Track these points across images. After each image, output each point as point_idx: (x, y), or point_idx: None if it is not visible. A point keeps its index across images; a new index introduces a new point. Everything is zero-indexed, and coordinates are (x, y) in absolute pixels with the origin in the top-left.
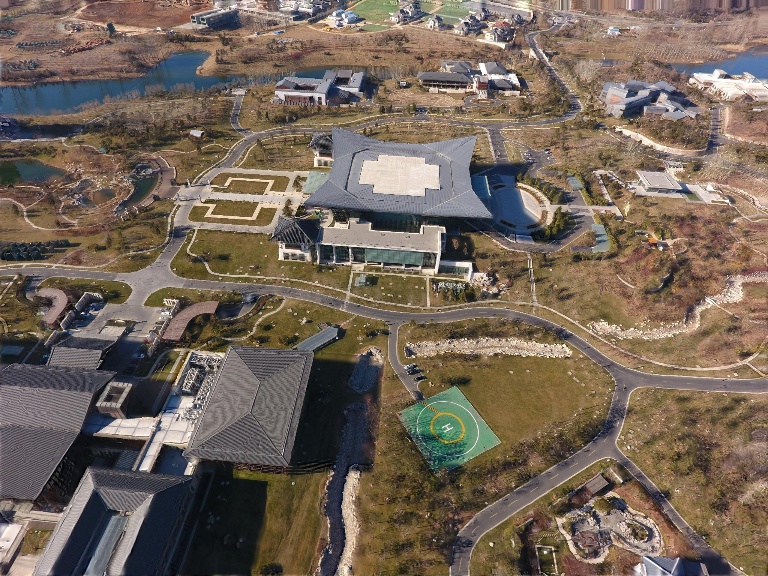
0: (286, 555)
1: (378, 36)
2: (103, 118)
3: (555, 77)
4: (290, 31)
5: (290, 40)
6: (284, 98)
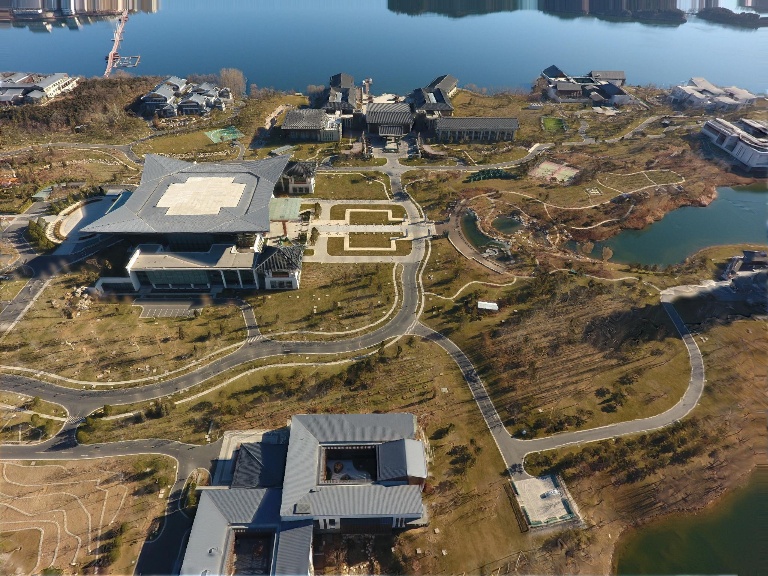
0: None
1: None
2: None
3: None
4: None
5: None
6: None
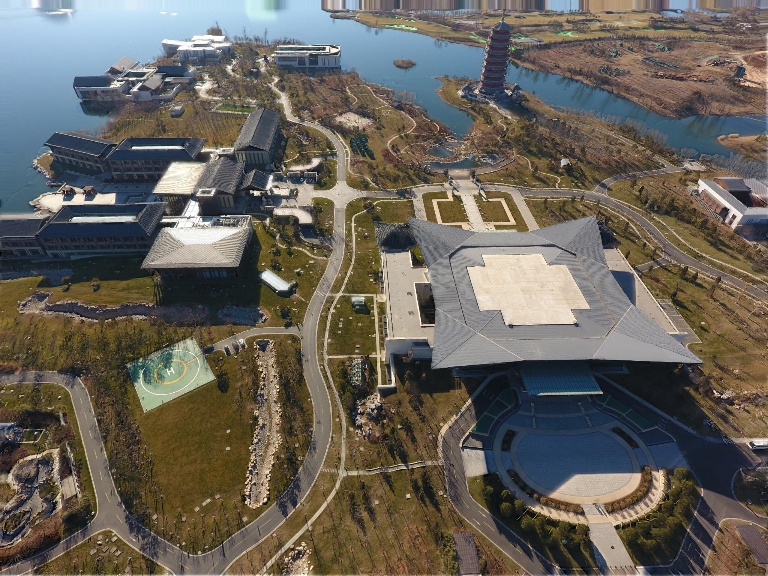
0: (102, 291)
1: None
2: (553, 120)
3: None
4: None
5: None
6: (702, 192)
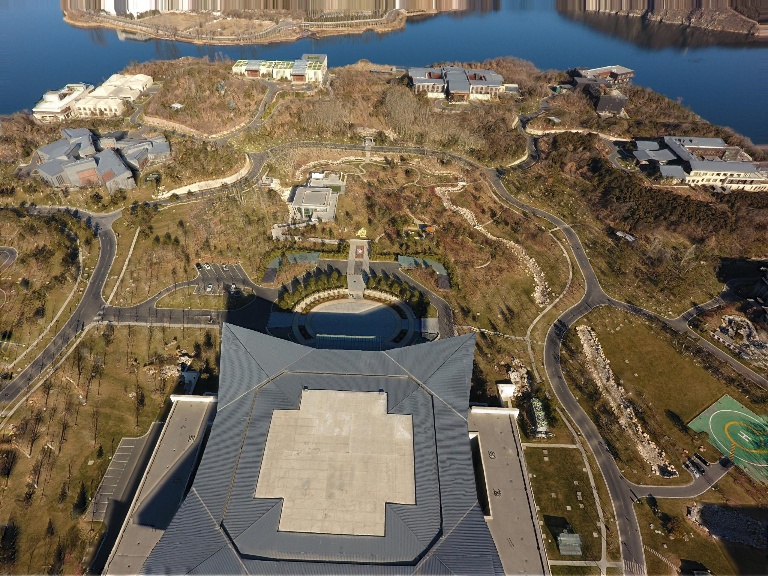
0: None
1: None
2: None
3: None
4: None
5: None
6: None
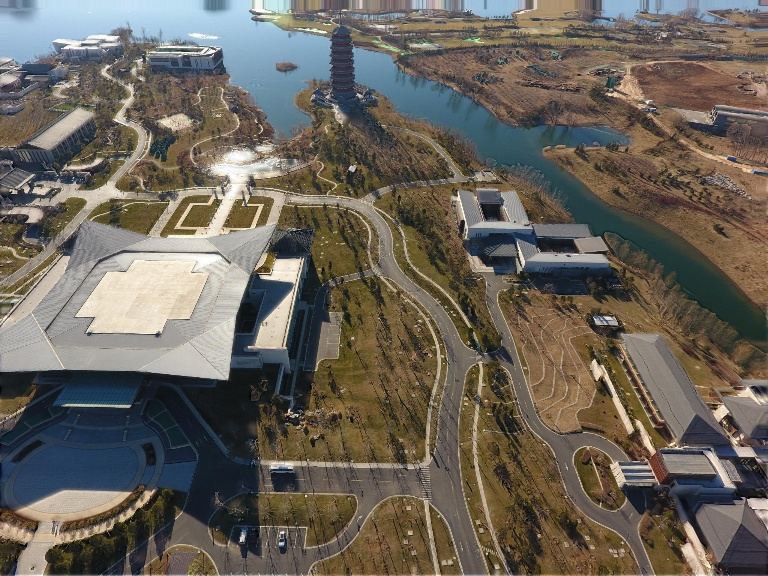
0: None
1: None
2: None
3: None
4: None
5: (728, 185)
6: None
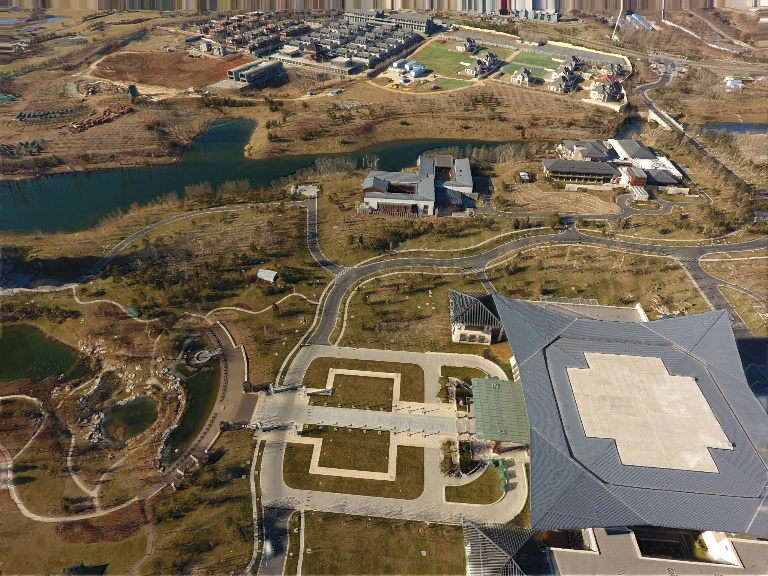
0: None
1: (460, 96)
2: (130, 245)
3: (711, 158)
4: (349, 90)
5: (354, 104)
6: (376, 206)
